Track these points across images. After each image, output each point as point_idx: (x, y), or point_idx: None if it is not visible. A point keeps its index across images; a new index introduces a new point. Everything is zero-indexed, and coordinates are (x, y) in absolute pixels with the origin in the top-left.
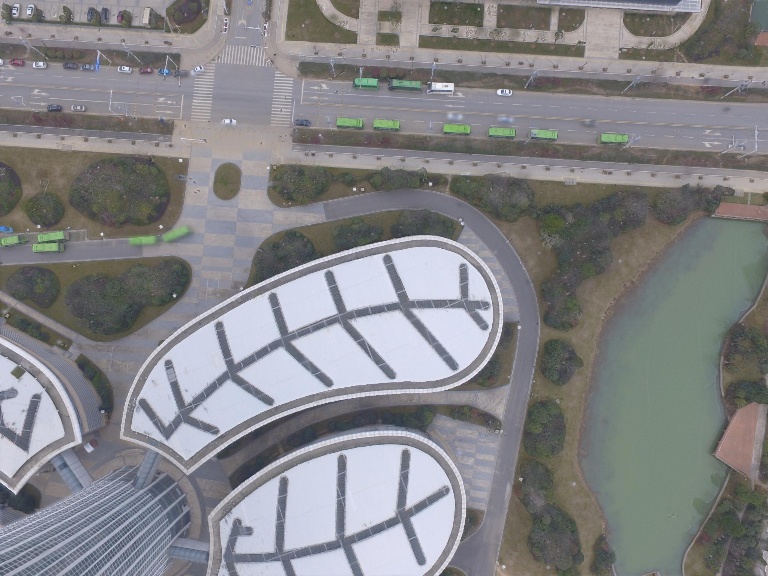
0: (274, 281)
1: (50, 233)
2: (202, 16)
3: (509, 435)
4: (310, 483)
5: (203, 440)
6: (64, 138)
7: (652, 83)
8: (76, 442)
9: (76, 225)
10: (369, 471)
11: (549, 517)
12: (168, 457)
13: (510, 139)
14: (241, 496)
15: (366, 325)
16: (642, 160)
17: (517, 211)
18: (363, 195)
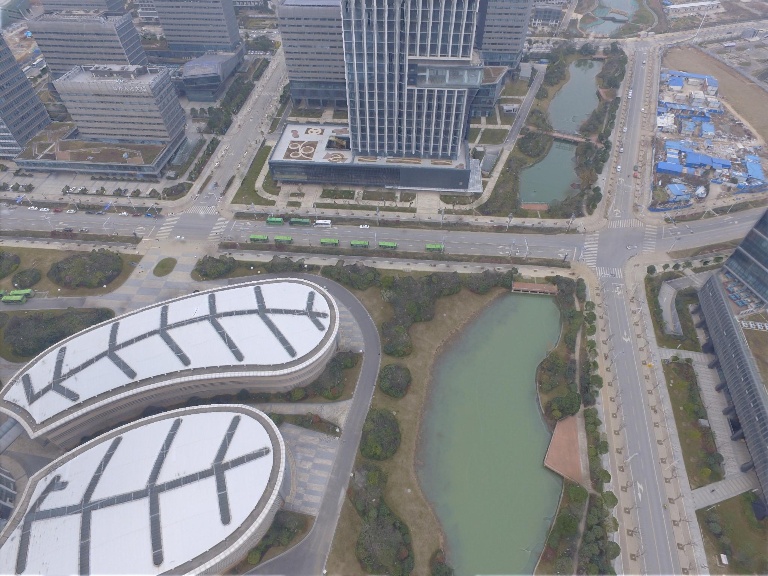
0: (170, 301)
1: (21, 290)
2: (183, 194)
3: (348, 442)
4: (141, 440)
5: (61, 406)
6: (65, 244)
7: (459, 223)
8: None
9: (43, 289)
10: (199, 430)
11: (375, 510)
12: (22, 422)
13: (366, 248)
14: (72, 457)
15: (228, 322)
16: (456, 259)
17: (366, 281)
18: (259, 275)
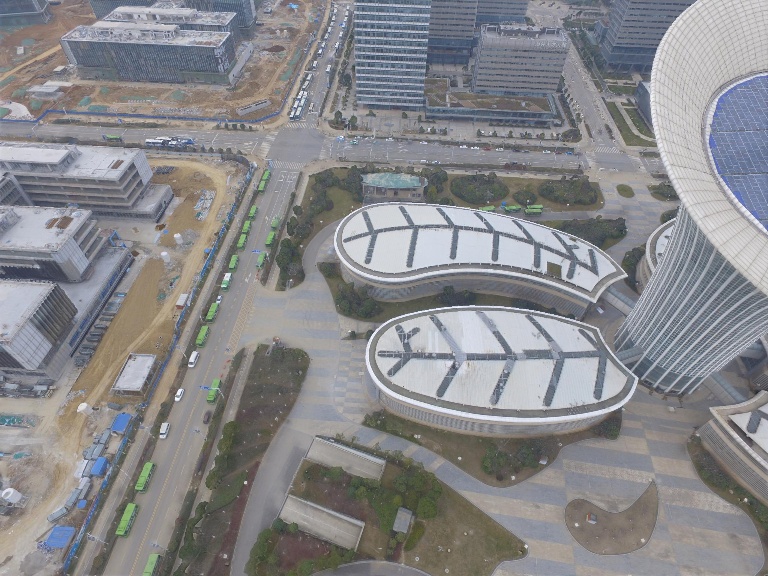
0: None
1: (534, 205)
2: (579, 137)
3: None
4: None
5: None
6: (523, 174)
7: None
8: (625, 275)
9: (544, 205)
10: None
11: None
12: None
13: None
14: None
15: None
16: None
17: None
18: None
